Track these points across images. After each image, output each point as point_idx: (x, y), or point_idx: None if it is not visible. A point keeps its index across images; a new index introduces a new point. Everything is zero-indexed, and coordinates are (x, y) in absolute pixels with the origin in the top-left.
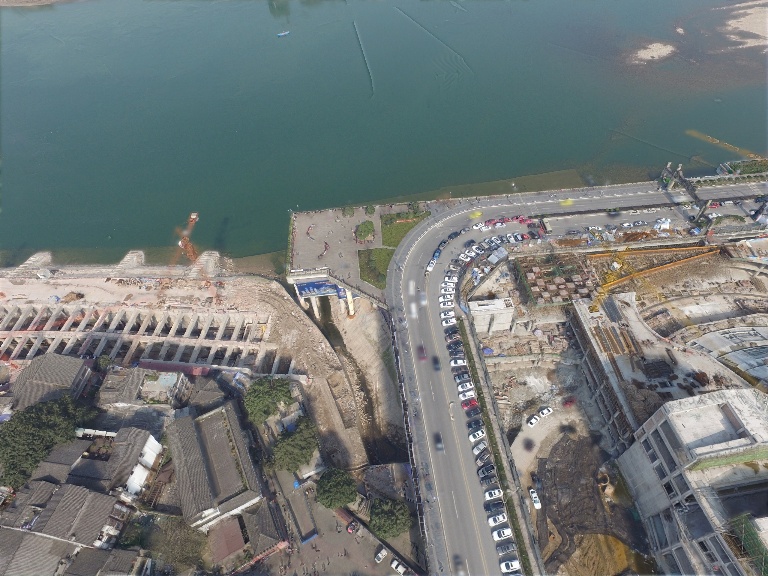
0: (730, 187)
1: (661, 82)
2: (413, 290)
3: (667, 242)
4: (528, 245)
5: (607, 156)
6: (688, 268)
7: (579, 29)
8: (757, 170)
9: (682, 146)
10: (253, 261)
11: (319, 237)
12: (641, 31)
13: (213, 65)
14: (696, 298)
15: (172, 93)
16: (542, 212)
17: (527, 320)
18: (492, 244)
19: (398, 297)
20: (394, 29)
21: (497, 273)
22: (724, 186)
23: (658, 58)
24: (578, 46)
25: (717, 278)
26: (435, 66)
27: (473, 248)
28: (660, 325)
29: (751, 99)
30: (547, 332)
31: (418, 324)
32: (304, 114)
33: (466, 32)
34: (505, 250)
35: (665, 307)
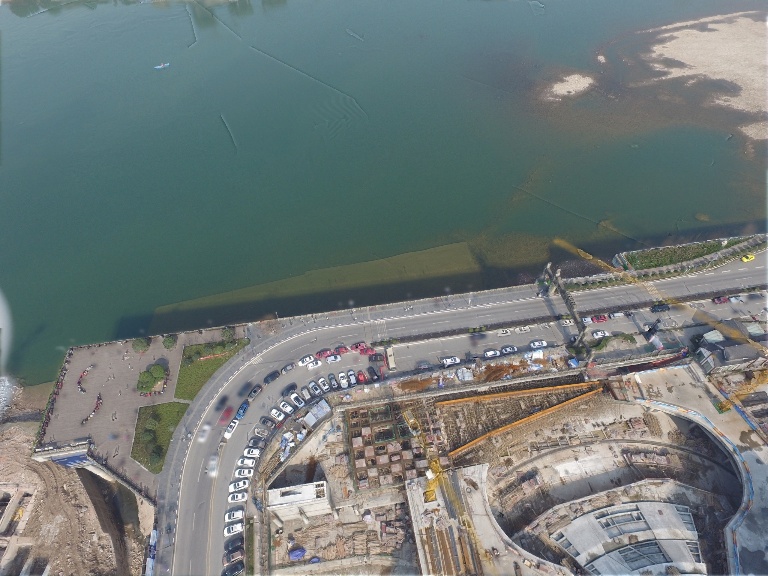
0: (624, 289)
1: (575, 124)
2: (198, 472)
3: (539, 377)
4: (363, 390)
5: (505, 223)
6: (563, 414)
7: (493, 57)
8: (657, 263)
9: (591, 207)
10: (50, 390)
11: (93, 387)
12: (560, 59)
13: (71, 107)
14: (575, 449)
15: (11, 146)
16: (391, 335)
17: (352, 504)
18: (316, 392)
19: (174, 487)
20: (255, 75)
21: (327, 426)
22: (617, 287)
23: (575, 93)
24: (490, 79)
25: (604, 416)
26: (314, 114)
27: (291, 398)
28: (524, 499)
29: (671, 144)
30: (380, 516)
31: (192, 533)
32: (146, 181)
33: (370, 62)
34: (327, 405)
35: (536, 466)
